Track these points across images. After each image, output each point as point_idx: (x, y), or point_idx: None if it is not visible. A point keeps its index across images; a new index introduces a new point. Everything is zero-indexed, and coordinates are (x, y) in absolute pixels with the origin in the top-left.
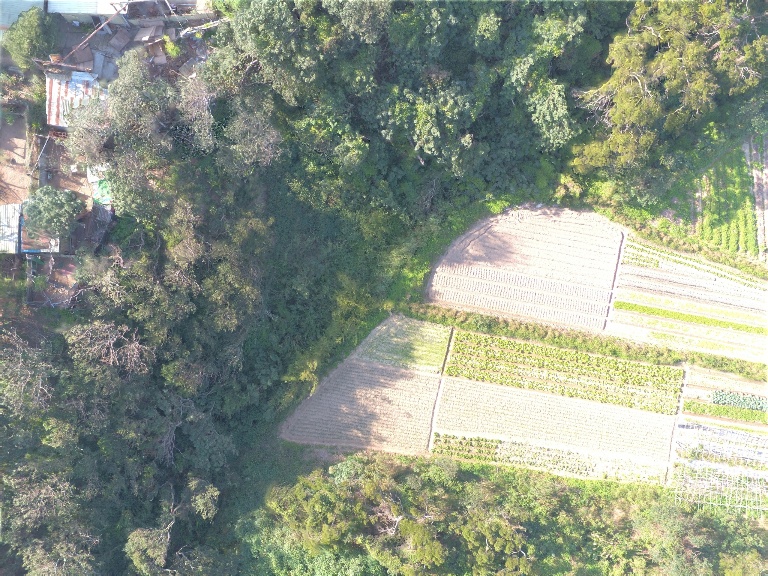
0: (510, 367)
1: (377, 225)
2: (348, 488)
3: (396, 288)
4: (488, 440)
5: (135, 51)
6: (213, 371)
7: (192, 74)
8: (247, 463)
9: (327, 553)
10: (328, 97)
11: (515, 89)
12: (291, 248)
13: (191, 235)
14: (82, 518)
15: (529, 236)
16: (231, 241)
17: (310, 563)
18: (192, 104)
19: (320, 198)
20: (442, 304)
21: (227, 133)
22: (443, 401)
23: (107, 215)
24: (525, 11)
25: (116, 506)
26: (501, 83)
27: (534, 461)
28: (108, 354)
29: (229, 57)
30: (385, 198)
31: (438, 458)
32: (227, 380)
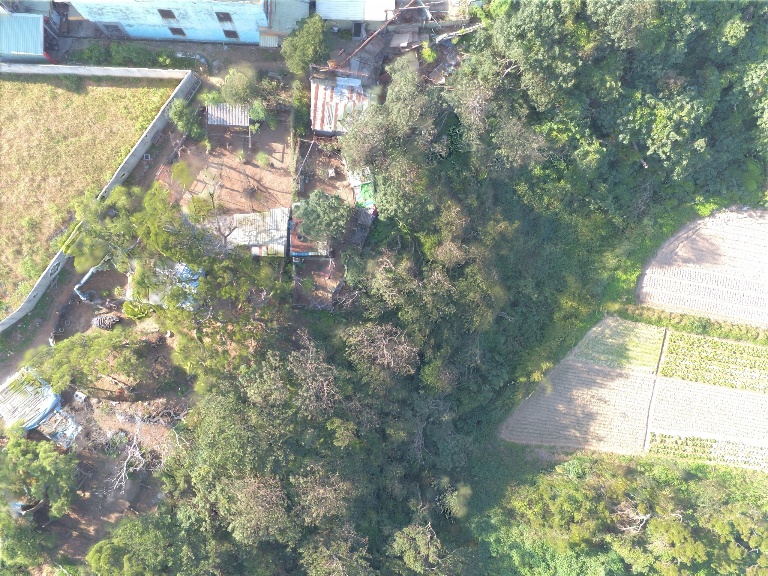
0: (723, 367)
1: (595, 228)
2: (591, 487)
3: (611, 290)
4: (703, 439)
5: (406, 57)
6: (456, 372)
7: (441, 79)
8: (474, 463)
9: (568, 551)
10: (576, 102)
11: (745, 94)
12: (515, 251)
13: (450, 238)
14: (349, 518)
15: (736, 238)
16: (483, 244)
17: (551, 561)
18: (471, 109)
19: (542, 201)
20: (654, 305)
21: (495, 138)
22: (658, 401)
23: (368, 219)
24: (758, 18)
25: (374, 506)
26: (727, 88)
27: (748, 460)
28: (383, 356)
29: (488, 63)
30: (604, 201)
31: (654, 457)
32: (464, 381)
